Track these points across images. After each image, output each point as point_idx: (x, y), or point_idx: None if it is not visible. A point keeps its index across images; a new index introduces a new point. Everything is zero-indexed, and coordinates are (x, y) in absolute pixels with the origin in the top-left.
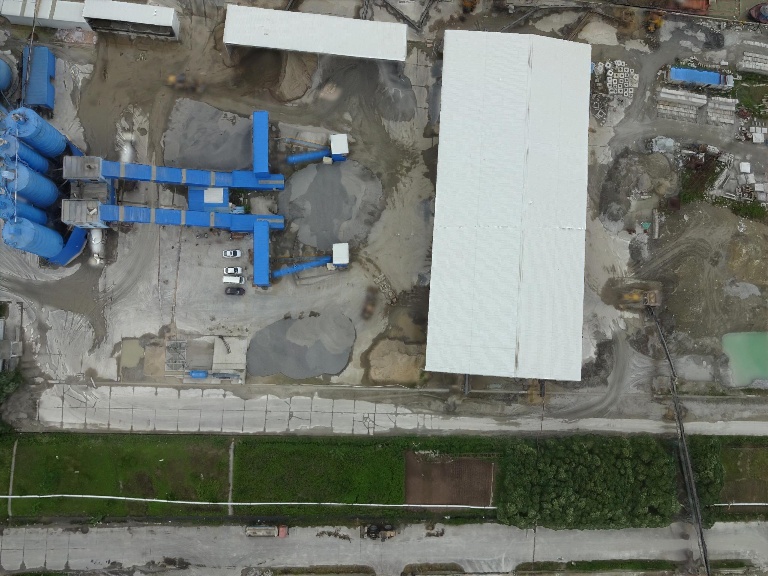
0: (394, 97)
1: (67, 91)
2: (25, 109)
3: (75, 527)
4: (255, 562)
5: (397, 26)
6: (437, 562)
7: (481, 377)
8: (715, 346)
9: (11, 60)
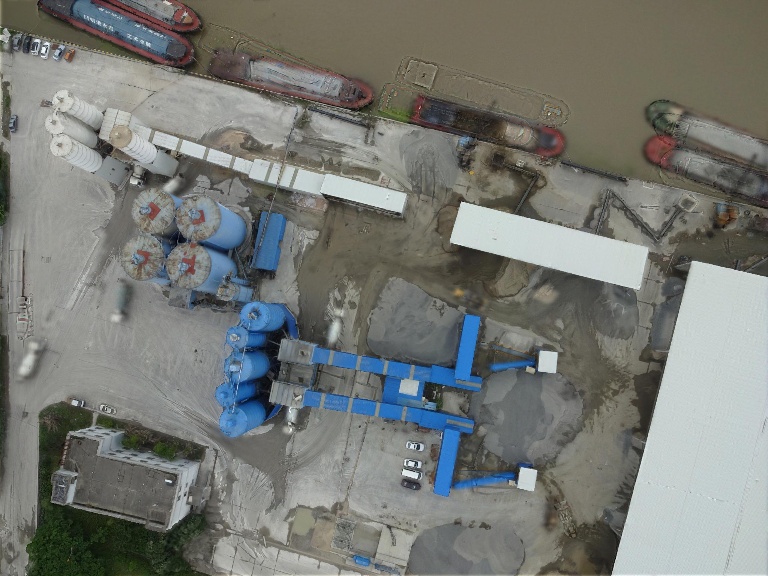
0: (615, 312)
1: (291, 254)
2: (260, 304)
3: None
4: None
5: (637, 248)
6: None
7: None
8: None
9: (248, 217)
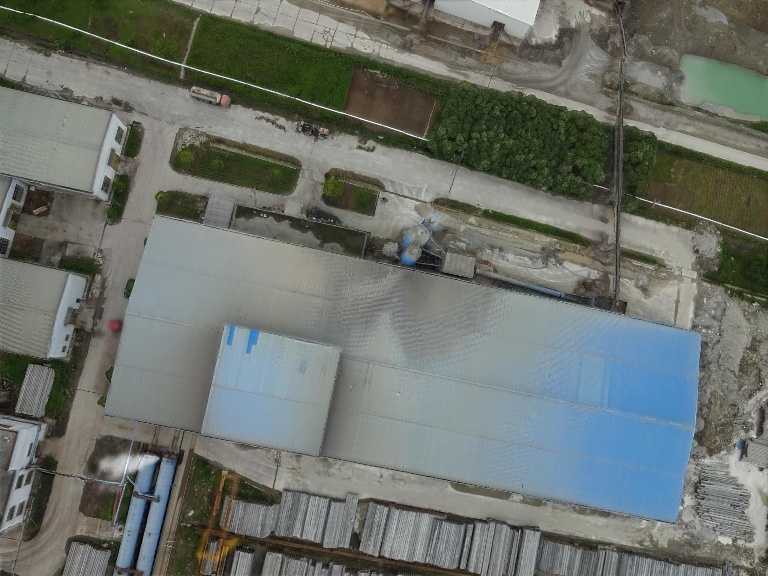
0: None
1: None
2: None
3: (40, 49)
4: (193, 125)
5: None
6: (362, 174)
7: (442, 26)
8: (673, 58)
9: None
